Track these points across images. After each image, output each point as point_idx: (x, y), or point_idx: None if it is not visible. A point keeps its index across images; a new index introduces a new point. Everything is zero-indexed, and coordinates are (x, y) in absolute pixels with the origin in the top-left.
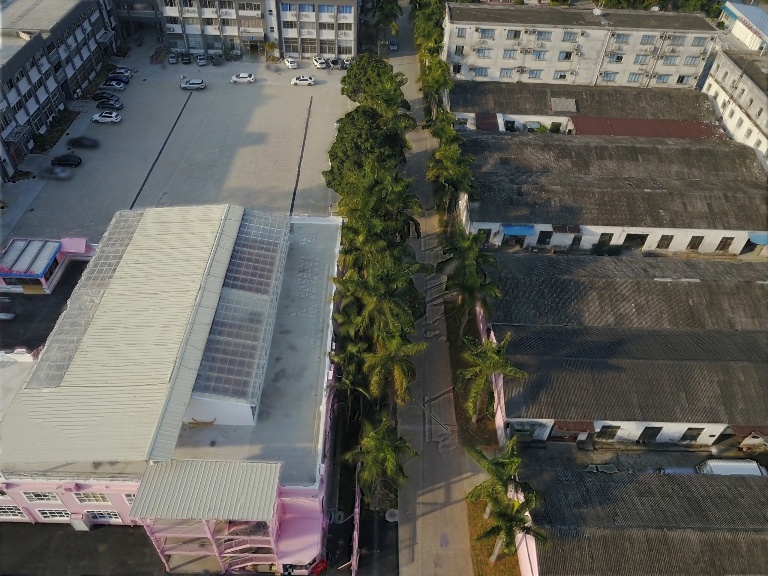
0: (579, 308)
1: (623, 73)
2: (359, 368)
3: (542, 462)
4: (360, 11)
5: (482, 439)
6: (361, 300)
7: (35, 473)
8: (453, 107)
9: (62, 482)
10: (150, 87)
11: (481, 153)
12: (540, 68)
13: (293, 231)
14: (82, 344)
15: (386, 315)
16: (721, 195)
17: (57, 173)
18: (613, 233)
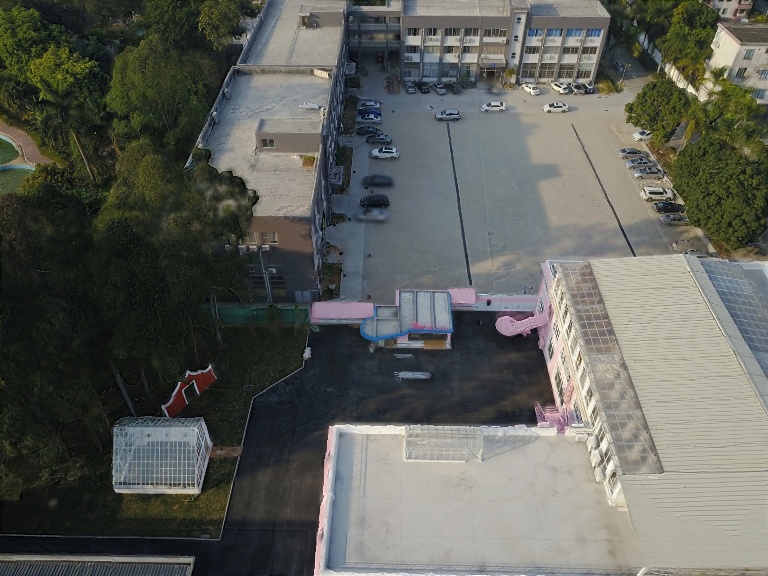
0: None
1: None
2: None
3: None
4: None
5: None
6: None
7: (656, 570)
8: None
9: None
10: (404, 119)
11: None
12: None
13: None
14: (649, 420)
15: None
16: None
17: (376, 215)
18: None
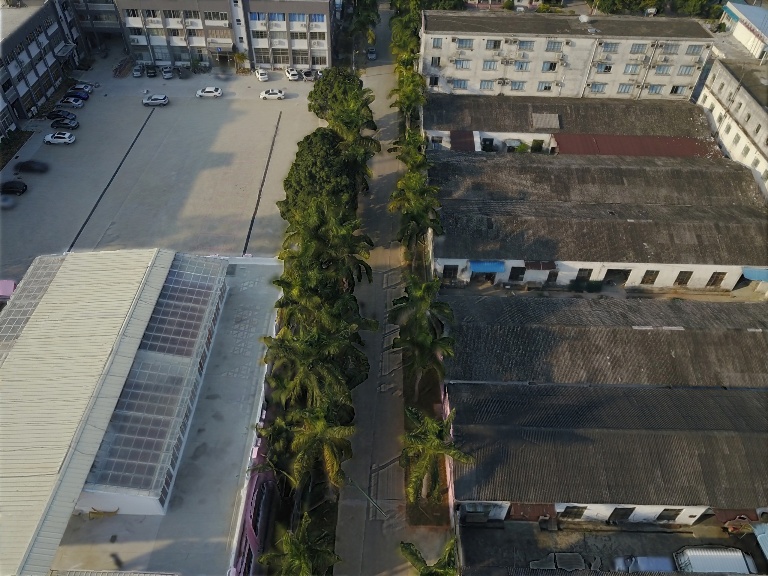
0: (547, 362)
1: (612, 84)
2: (287, 445)
3: (498, 546)
4: (340, 17)
5: (432, 517)
6: (295, 362)
7: None
8: (426, 125)
9: None
10: (111, 103)
11: (452, 178)
12: (523, 79)
13: (235, 274)
14: None
15: (314, 388)
16: (712, 225)
17: None
18: (592, 268)
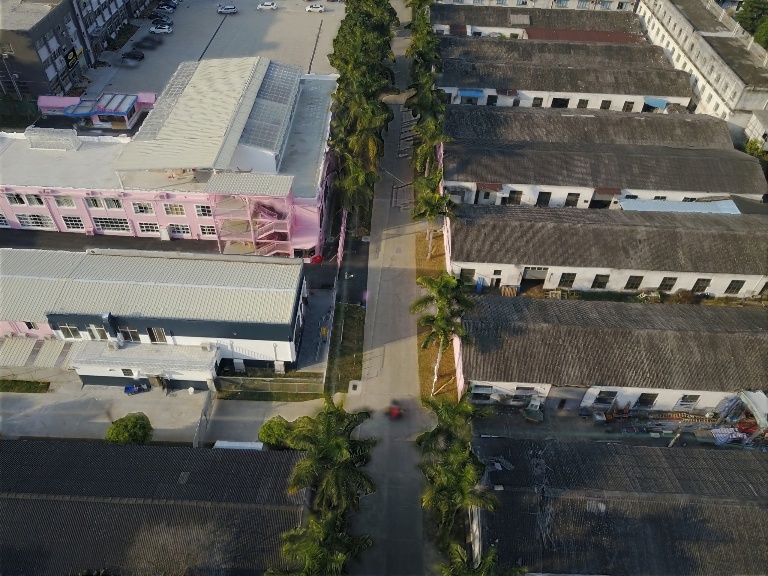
0: (505, 131)
1: None
2: (346, 145)
3: None
4: None
5: None
6: (349, 109)
7: None
8: (432, 20)
9: (158, 192)
10: (193, 12)
11: (449, 47)
12: None
13: (305, 83)
14: (167, 122)
15: (364, 105)
16: (626, 71)
17: (127, 62)
18: (543, 98)
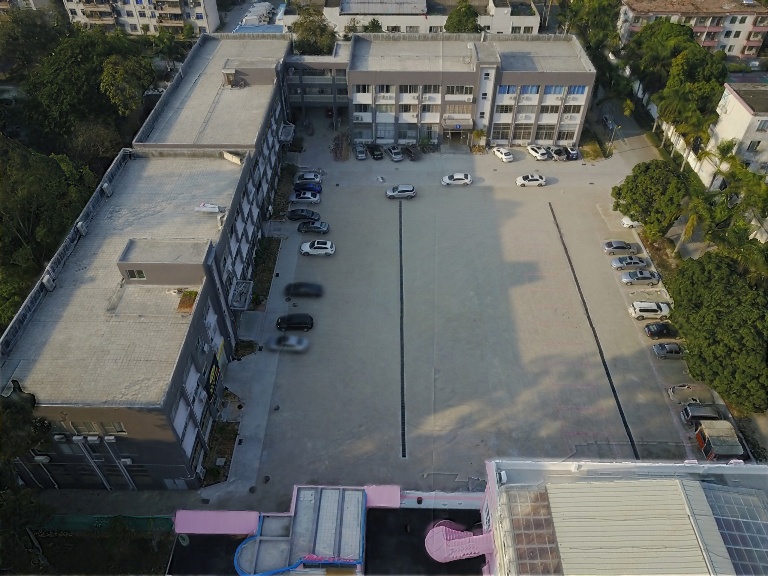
0: None
1: None
2: None
3: None
4: None
5: None
6: None
7: None
8: None
9: None
10: (348, 196)
11: None
12: None
13: None
14: None
15: None
16: None
17: (293, 345)
18: None
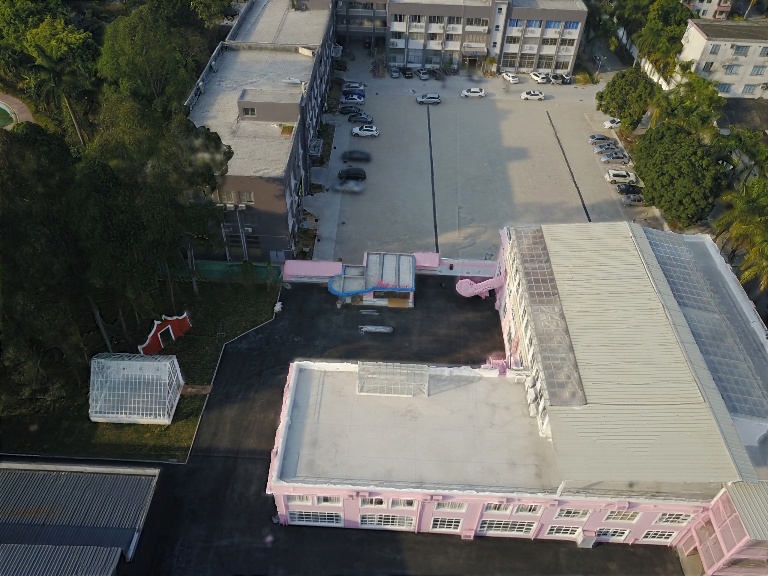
0: None
1: None
2: None
3: None
4: None
5: None
6: None
7: (576, 490)
8: (721, 123)
9: (614, 500)
10: (386, 101)
11: None
12: None
13: None
14: (579, 361)
15: None
16: None
17: (353, 186)
18: None
